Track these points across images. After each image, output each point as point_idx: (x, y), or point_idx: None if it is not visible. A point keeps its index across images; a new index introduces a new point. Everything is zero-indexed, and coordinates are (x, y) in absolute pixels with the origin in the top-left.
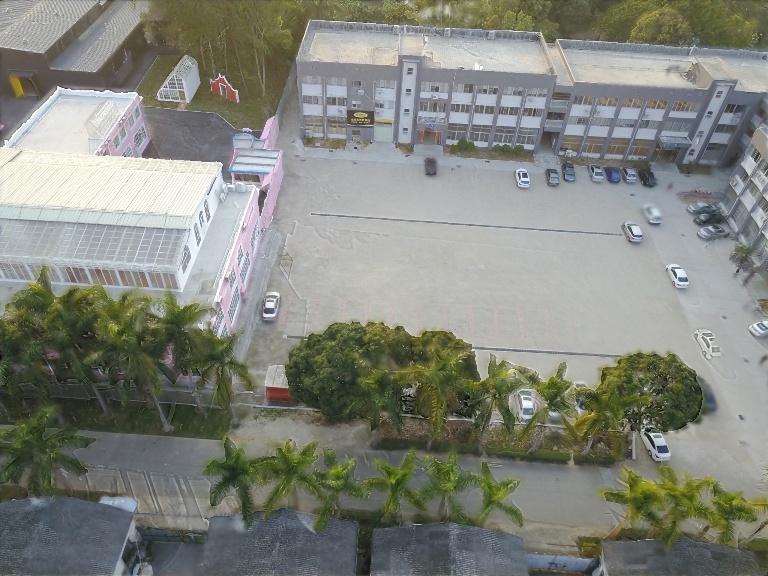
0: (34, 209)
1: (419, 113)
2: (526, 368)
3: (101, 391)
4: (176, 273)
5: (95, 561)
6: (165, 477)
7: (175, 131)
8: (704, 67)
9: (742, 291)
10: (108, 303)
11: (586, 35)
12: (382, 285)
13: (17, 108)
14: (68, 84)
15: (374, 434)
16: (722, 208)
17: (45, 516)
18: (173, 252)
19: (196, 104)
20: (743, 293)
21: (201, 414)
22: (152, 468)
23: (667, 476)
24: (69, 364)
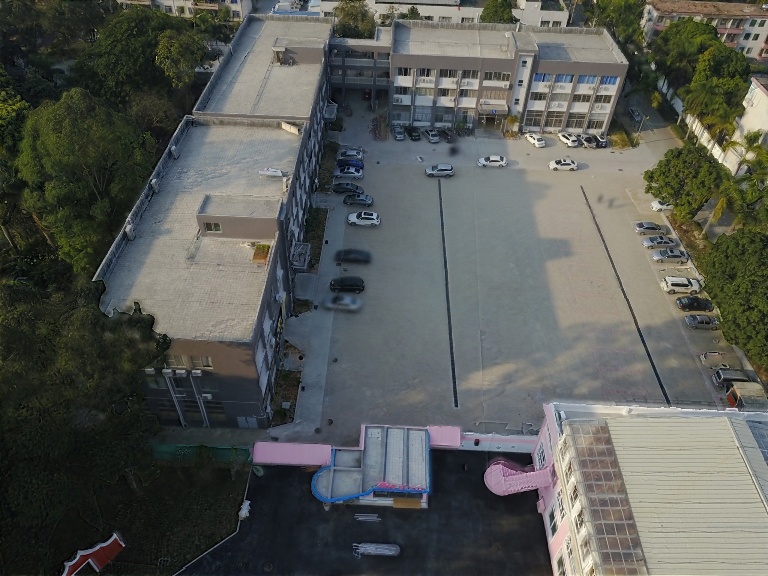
0: None
1: None
2: (741, 205)
3: None
4: None
5: None
6: None
7: None
8: (297, 47)
9: (496, 141)
10: None
11: None
12: (568, 337)
13: None
14: None
15: None
16: (400, 123)
17: None
18: None
19: None
20: (498, 141)
21: None
22: None
23: (762, 176)
24: None
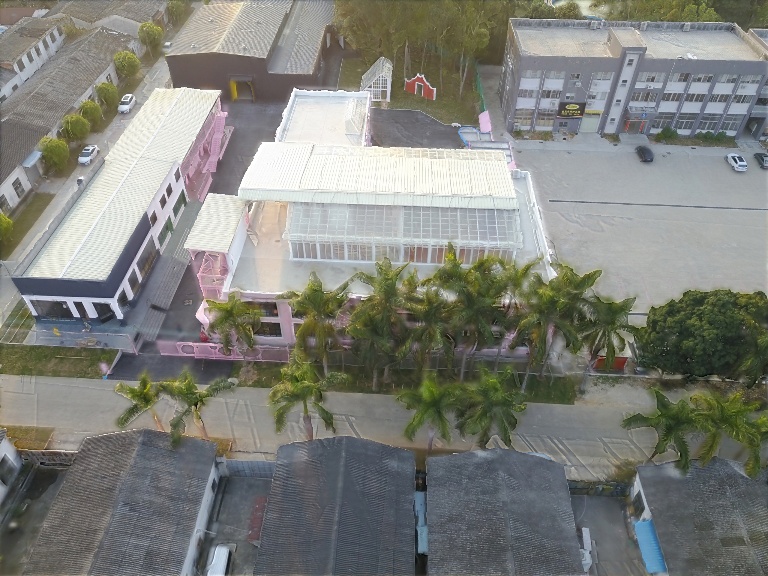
0: (369, 195)
1: (630, 103)
2: None
3: (466, 360)
4: (515, 250)
5: (556, 505)
6: (540, 438)
7: (390, 128)
8: None
9: None
10: (515, 272)
11: (750, 26)
12: (648, 264)
13: (237, 111)
14: (282, 87)
15: (713, 397)
16: None
17: (501, 466)
18: (511, 230)
19: (396, 103)
20: None
21: (545, 382)
22: (524, 430)
23: None
24: (466, 331)
